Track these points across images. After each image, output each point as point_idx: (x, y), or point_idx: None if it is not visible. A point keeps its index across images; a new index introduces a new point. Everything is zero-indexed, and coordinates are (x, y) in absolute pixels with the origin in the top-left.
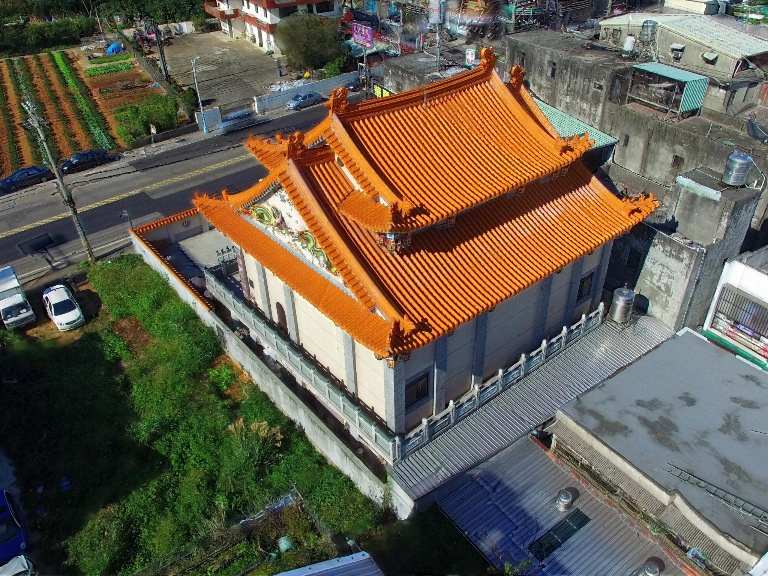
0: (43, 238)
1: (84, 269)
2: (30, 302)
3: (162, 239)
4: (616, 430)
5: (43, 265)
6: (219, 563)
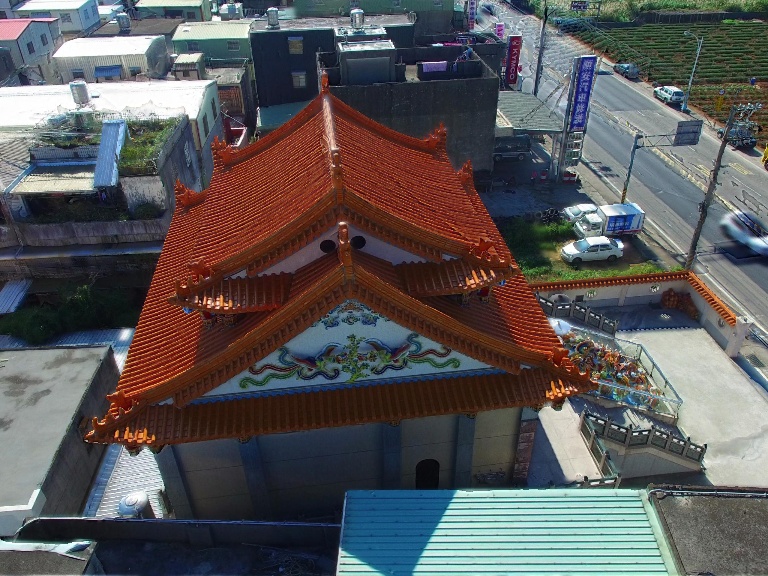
0: (750, 253)
1: (670, 270)
2: (623, 243)
3: (699, 308)
4: (57, 361)
5: (687, 249)
6: (154, 148)
